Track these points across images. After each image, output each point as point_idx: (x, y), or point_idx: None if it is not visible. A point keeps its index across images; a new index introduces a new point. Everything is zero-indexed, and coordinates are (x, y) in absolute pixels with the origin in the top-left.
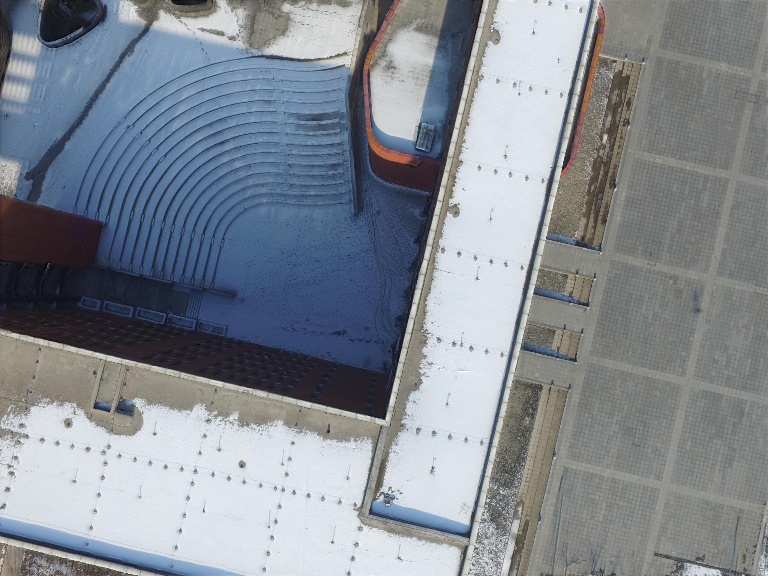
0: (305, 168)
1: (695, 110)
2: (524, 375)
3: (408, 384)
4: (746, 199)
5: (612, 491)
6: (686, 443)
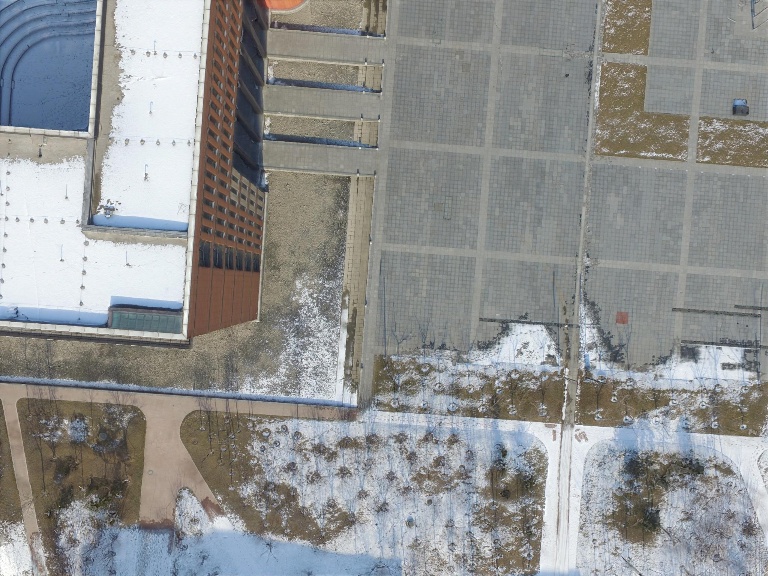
0: None
1: None
2: (329, 169)
3: (110, 99)
4: None
5: (431, 266)
6: (494, 210)
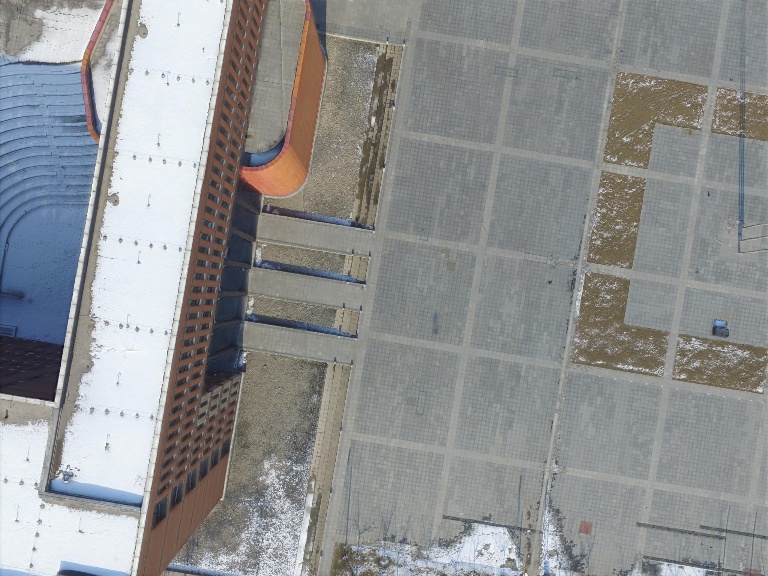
0: (79, 169)
1: (457, 88)
2: (307, 354)
3: (80, 367)
4: (511, 170)
5: (399, 460)
6: (467, 409)
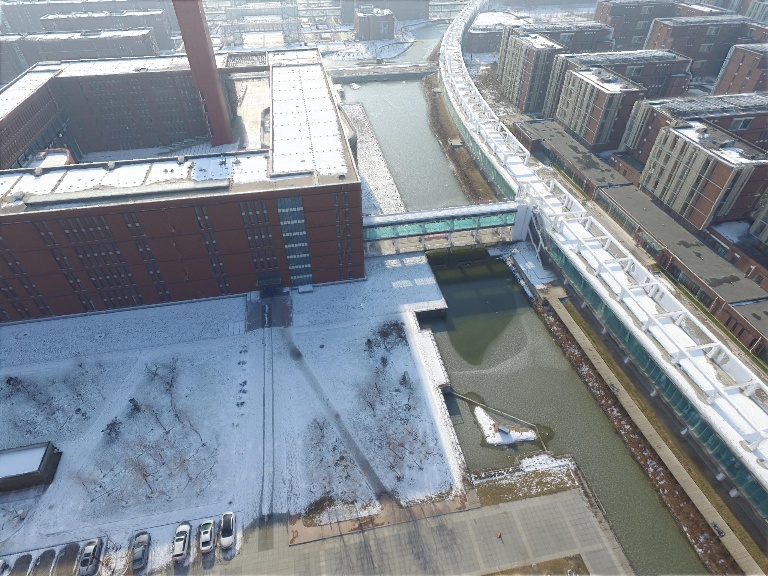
0: None
1: None
2: None
3: None
4: None
5: None
6: None
